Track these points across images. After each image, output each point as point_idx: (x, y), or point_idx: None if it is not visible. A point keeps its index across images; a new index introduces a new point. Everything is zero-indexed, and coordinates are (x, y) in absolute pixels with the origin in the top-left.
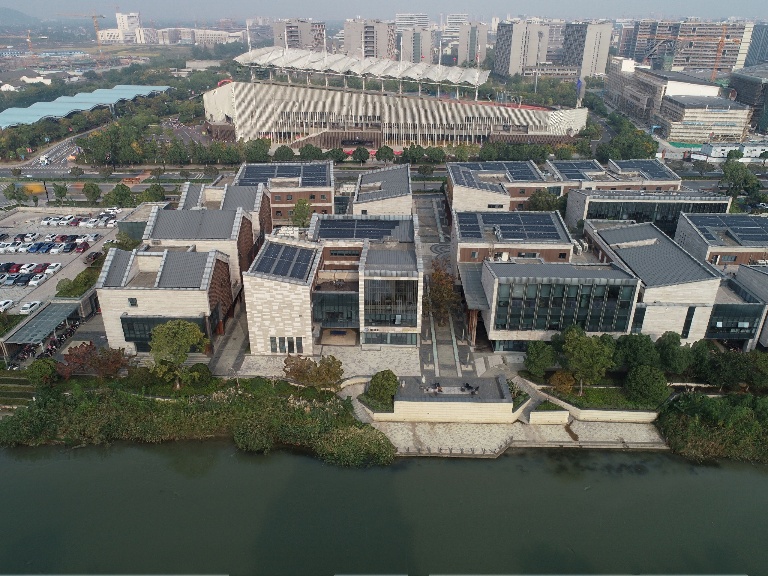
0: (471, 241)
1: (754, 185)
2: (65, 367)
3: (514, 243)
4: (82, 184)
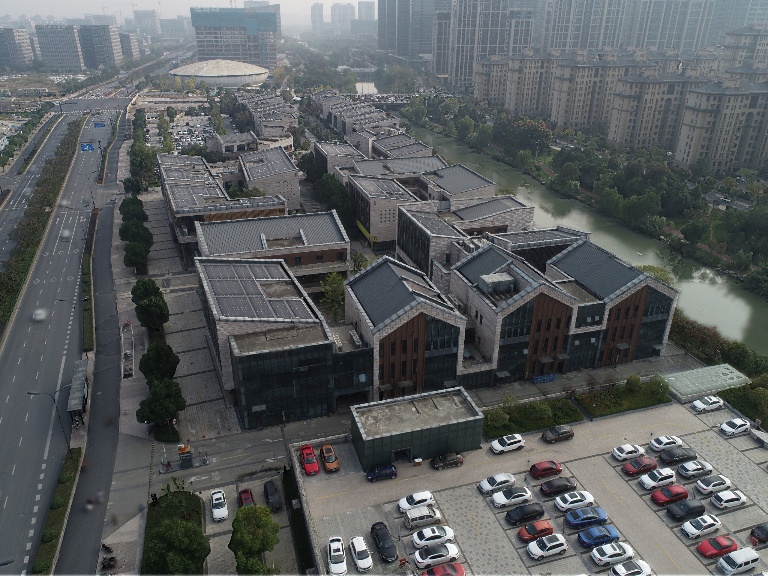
0: (417, 199)
1: None
2: (720, 340)
3: None
4: None
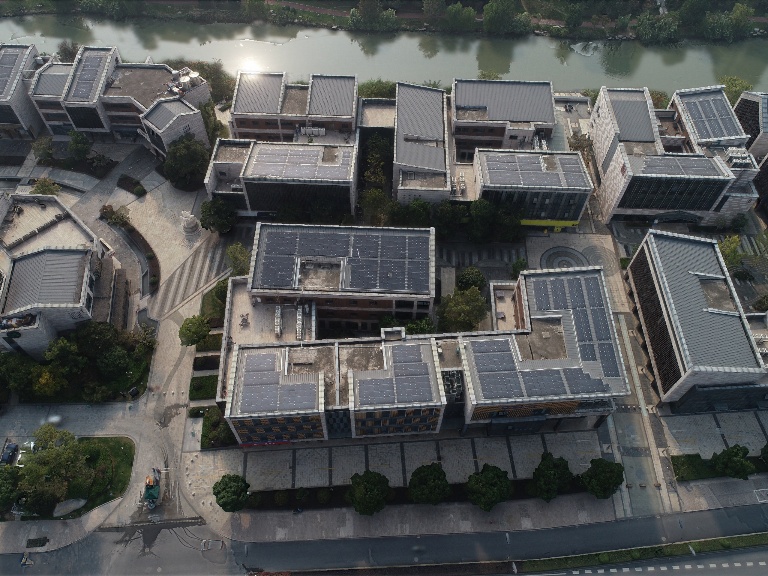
0: (568, 154)
1: (18, 466)
2: None
3: (529, 150)
4: None
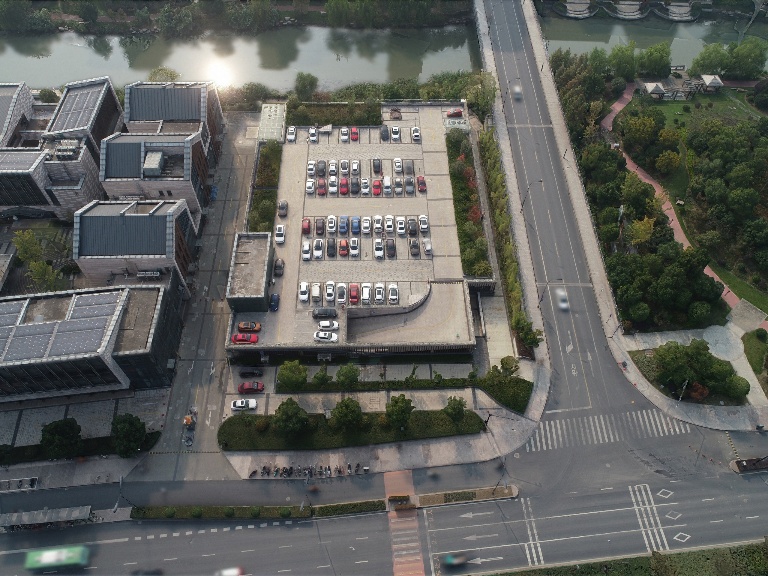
0: None
1: None
2: (237, 92)
3: None
4: (509, 570)
